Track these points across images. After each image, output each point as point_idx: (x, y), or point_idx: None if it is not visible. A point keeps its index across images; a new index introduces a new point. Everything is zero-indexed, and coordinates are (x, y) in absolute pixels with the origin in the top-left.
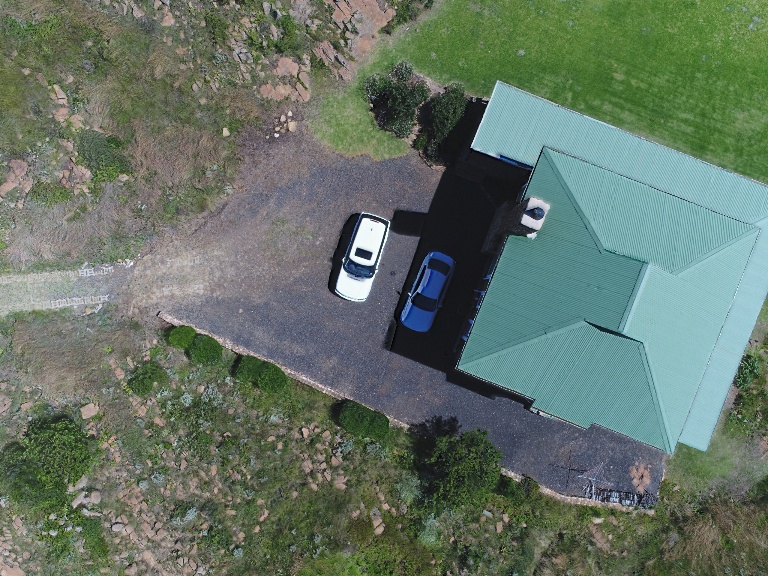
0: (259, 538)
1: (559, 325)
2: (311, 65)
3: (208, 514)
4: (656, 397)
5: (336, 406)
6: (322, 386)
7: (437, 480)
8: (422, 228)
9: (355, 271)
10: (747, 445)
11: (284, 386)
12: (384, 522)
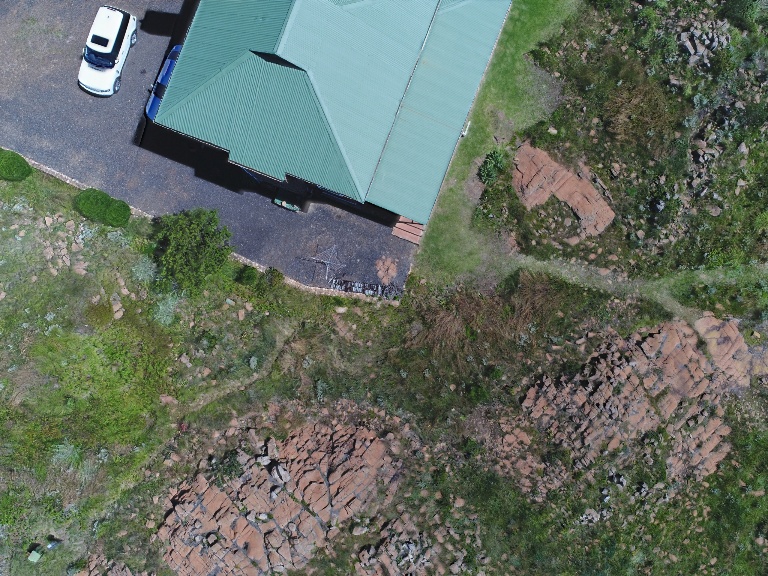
0: None
1: (231, 60)
2: None
3: None
4: (332, 135)
5: None
6: (66, 176)
7: None
8: (173, 28)
9: (95, 61)
10: (494, 241)
11: (30, 177)
12: (124, 307)
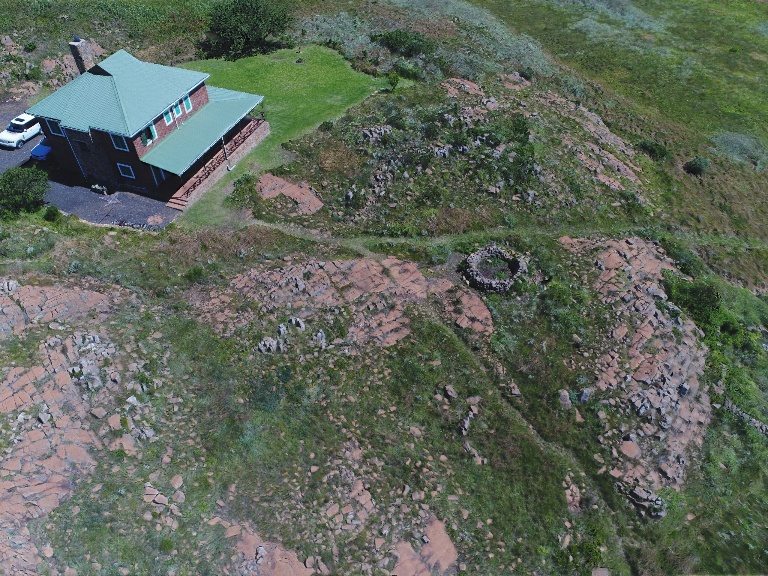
0: None
1: None
2: None
3: None
4: (120, 103)
5: None
6: None
7: None
8: None
9: (12, 130)
10: (237, 212)
11: None
12: None
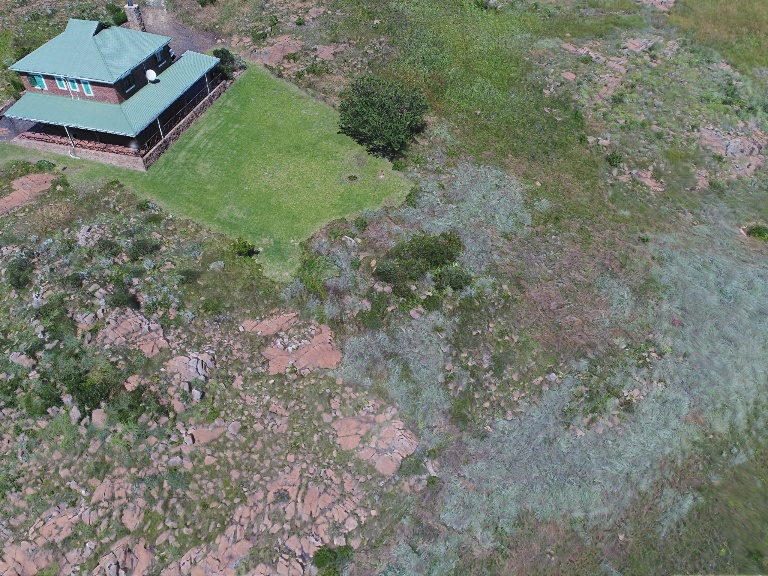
0: None
1: None
2: None
3: None
4: None
5: None
6: None
7: None
8: None
9: None
10: None
11: None
12: None
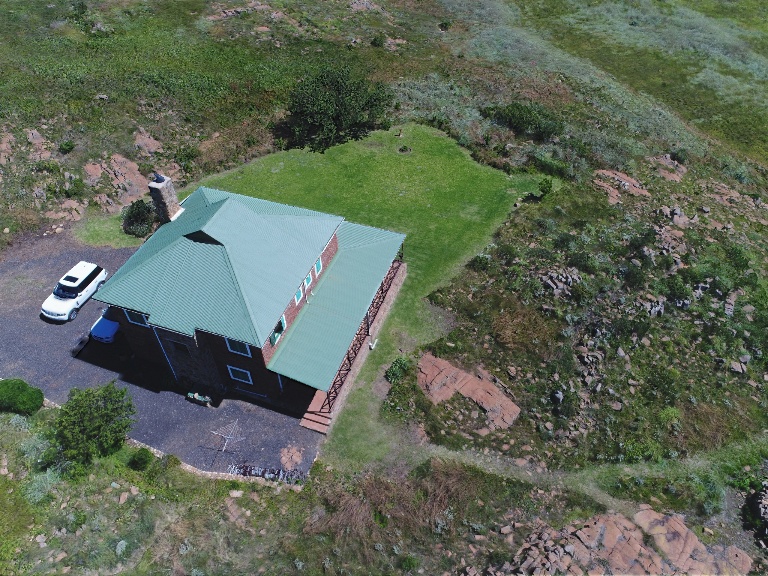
0: None
1: (167, 245)
2: (88, 205)
3: None
4: (240, 291)
5: None
6: None
7: None
8: None
9: (62, 294)
10: (403, 431)
11: None
12: None
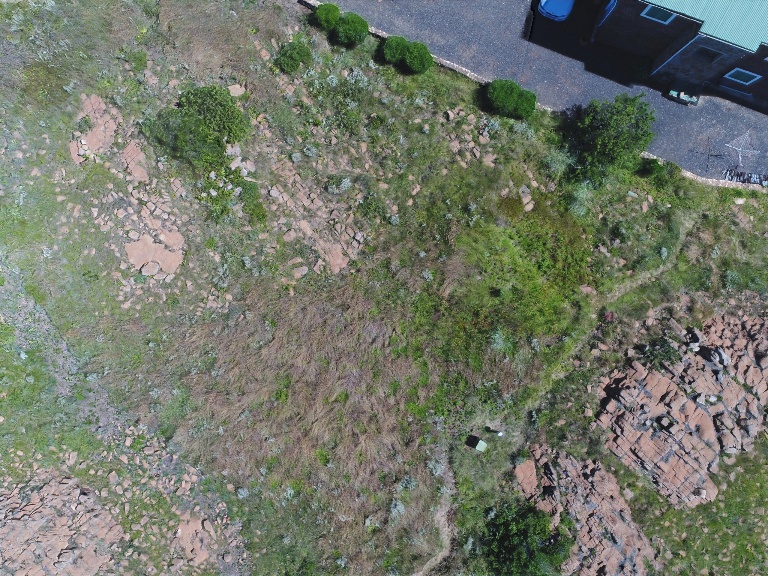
0: (413, 211)
1: None
2: None
3: (363, 184)
4: None
5: (480, 90)
6: (466, 69)
7: (586, 153)
8: None
9: None
10: None
11: (427, 72)
12: (533, 199)
